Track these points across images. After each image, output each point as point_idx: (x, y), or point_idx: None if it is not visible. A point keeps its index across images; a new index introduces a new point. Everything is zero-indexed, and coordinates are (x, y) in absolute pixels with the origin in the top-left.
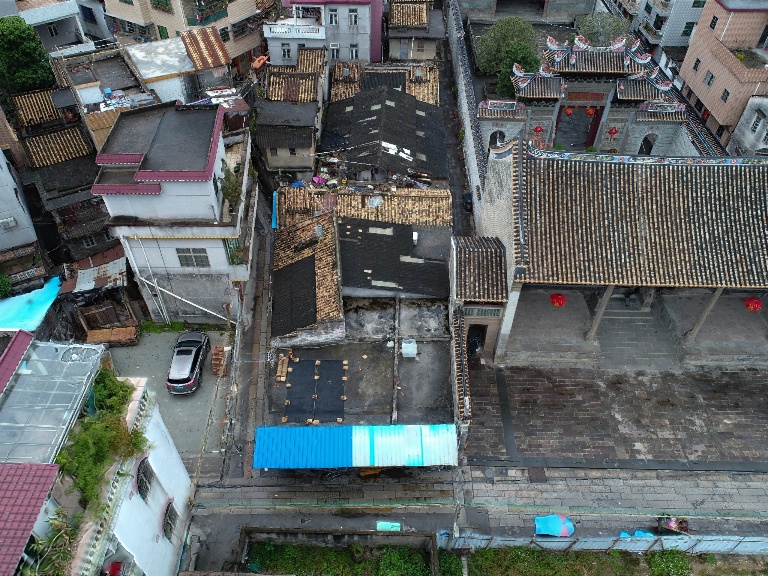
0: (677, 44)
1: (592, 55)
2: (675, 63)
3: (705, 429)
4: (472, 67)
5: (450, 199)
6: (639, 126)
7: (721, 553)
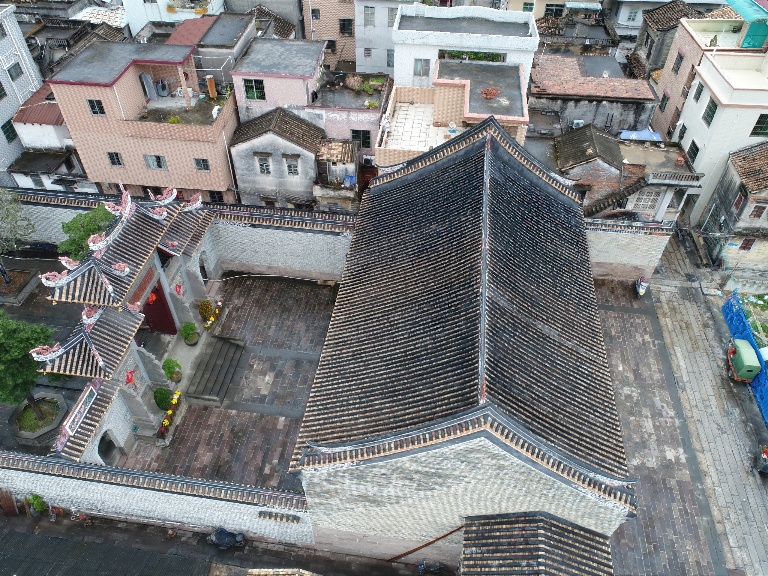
0: (13, 155)
1: (119, 244)
2: (55, 175)
3: (634, 389)
4: None
5: (305, 574)
6: (190, 260)
7: (767, 431)
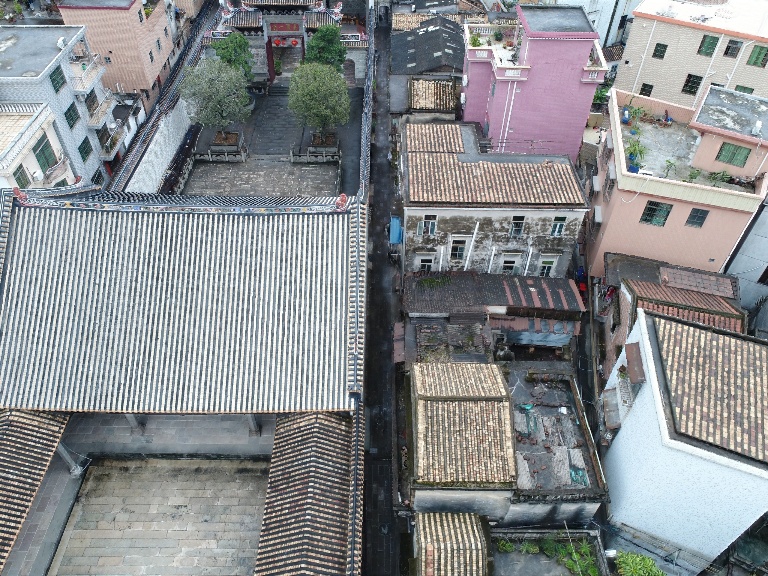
0: None
1: None
2: None
3: None
4: (344, 180)
5: None
6: None
7: None
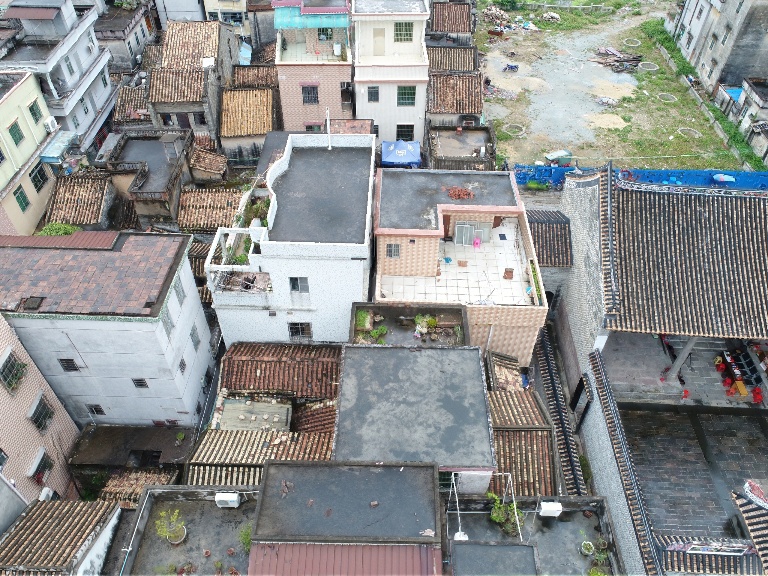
0: None
1: None
2: None
3: None
4: None
5: None
6: None
7: None
